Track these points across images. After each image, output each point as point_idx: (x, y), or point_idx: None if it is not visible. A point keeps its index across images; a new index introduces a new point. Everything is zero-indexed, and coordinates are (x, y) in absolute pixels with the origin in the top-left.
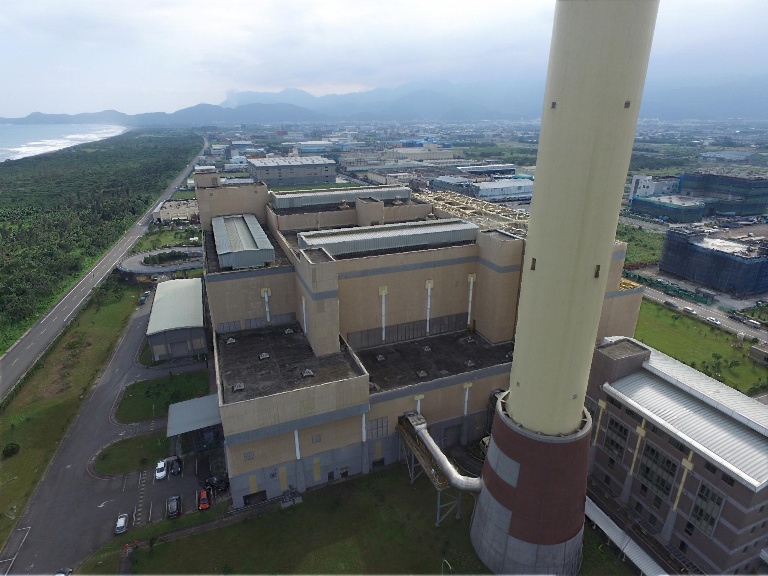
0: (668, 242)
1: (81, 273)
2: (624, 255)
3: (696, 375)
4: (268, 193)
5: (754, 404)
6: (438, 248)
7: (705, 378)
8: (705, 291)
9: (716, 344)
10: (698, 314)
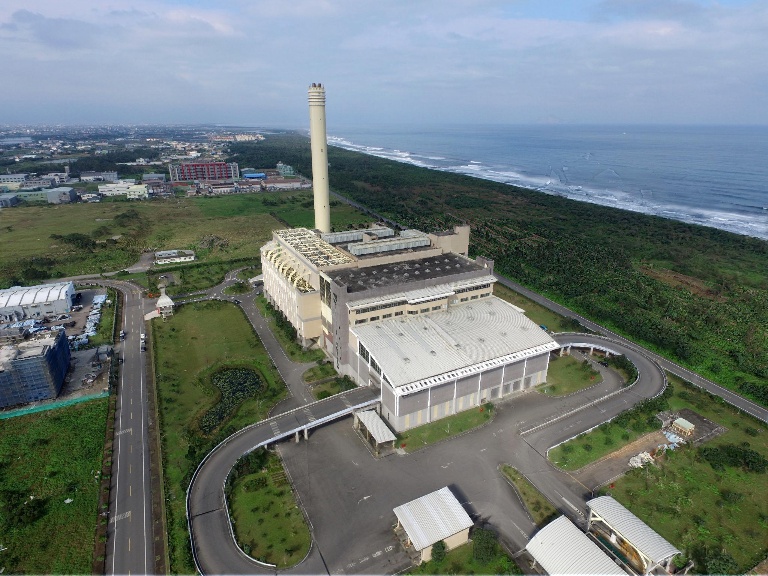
0: (50, 365)
1: (664, 354)
2: None
3: None
4: (429, 237)
5: None
6: None
7: None
8: (103, 349)
9: (176, 320)
10: (140, 342)
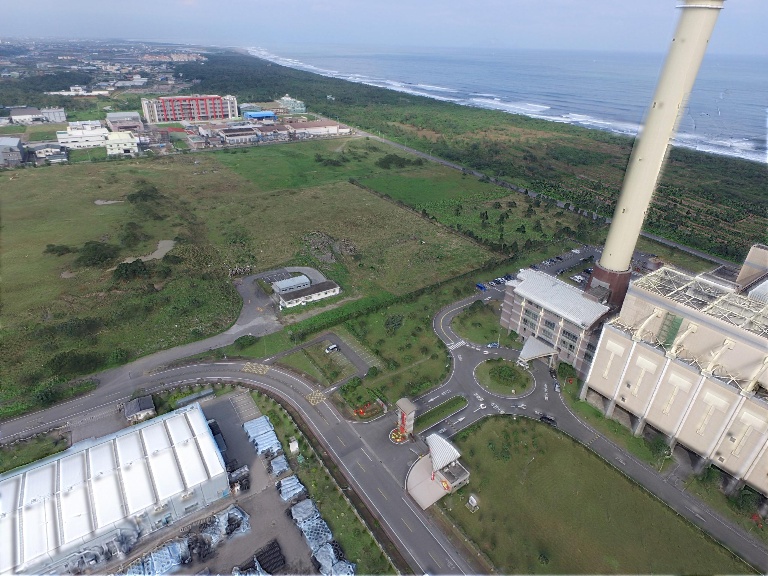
0: None
1: None
2: None
3: (560, 295)
4: None
5: (538, 285)
6: (750, 284)
7: (556, 295)
8: None
9: (496, 505)
10: None
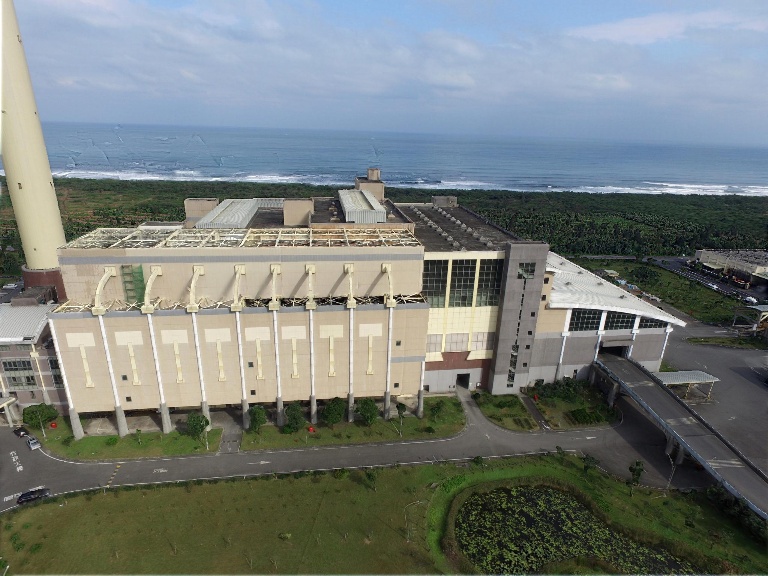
0: None
1: None
2: (60, 260)
3: None
4: (360, 189)
5: None
6: None
7: None
8: None
9: None
10: None
